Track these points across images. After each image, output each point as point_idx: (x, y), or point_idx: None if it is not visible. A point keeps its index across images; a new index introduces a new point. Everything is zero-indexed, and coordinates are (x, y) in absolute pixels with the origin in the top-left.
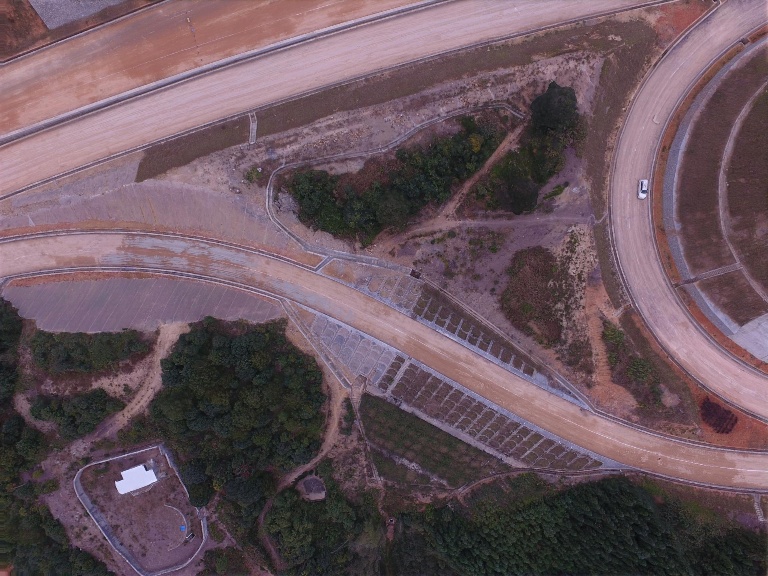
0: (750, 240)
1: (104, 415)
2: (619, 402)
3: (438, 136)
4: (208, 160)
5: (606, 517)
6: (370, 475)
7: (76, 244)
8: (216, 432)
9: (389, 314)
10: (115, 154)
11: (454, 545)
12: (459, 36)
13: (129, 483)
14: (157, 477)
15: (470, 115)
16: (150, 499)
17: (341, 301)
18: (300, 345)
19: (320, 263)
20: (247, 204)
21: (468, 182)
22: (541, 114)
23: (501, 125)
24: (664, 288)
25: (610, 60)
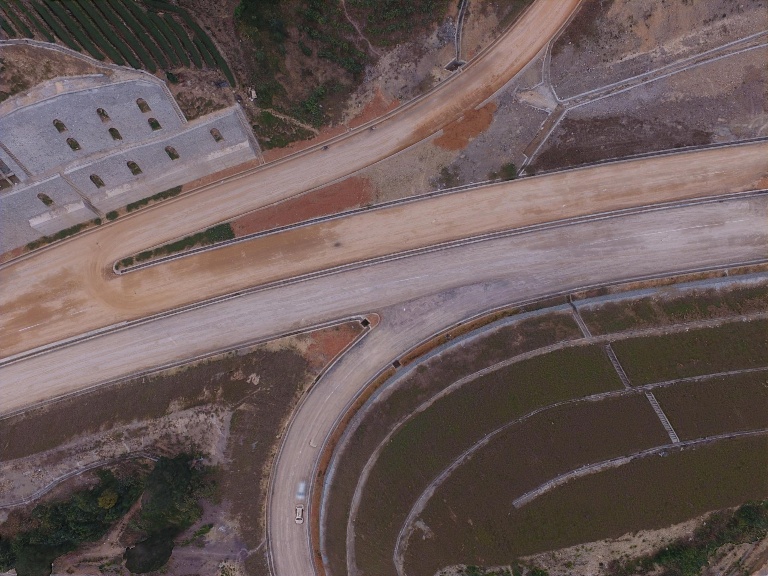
0: None
1: None
2: None
3: (72, 494)
4: None
5: None
6: None
7: None
8: None
9: None
10: None
11: None
12: (116, 366)
13: None
14: None
15: (106, 468)
16: None
17: None
18: None
19: None
20: None
21: (126, 514)
22: None
23: (144, 470)
24: None
25: (241, 410)
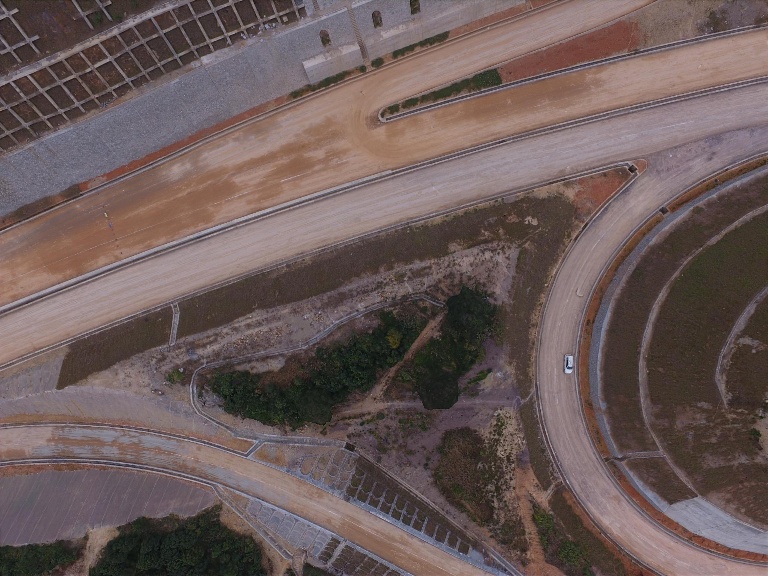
0: (671, 430)
1: None
2: None
3: (356, 334)
4: (128, 364)
5: None
6: None
7: (6, 438)
8: None
9: (322, 496)
10: (39, 350)
11: None
12: (379, 217)
13: None
14: None
15: (388, 310)
16: None
17: (274, 485)
18: (236, 526)
19: (251, 448)
20: (171, 403)
21: (393, 366)
22: (455, 317)
23: (421, 314)
24: (595, 462)
25: (526, 248)
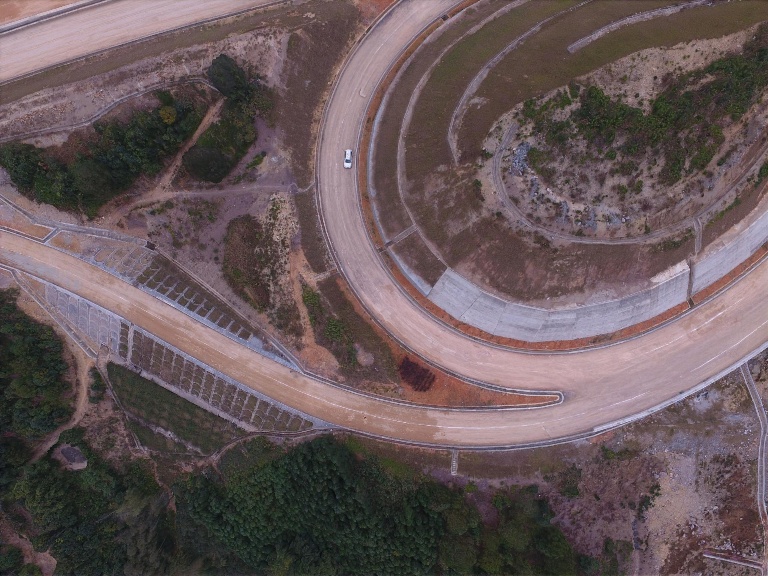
0: (422, 202)
1: None
2: (326, 363)
3: (132, 109)
4: None
5: (305, 473)
6: (133, 445)
7: None
8: None
9: (113, 283)
10: None
11: (205, 511)
12: (175, 17)
13: None
14: None
15: (166, 89)
16: None
17: (69, 271)
18: (36, 315)
19: (48, 235)
20: None
21: (180, 154)
22: None
23: (201, 99)
24: (370, 253)
25: (298, 35)
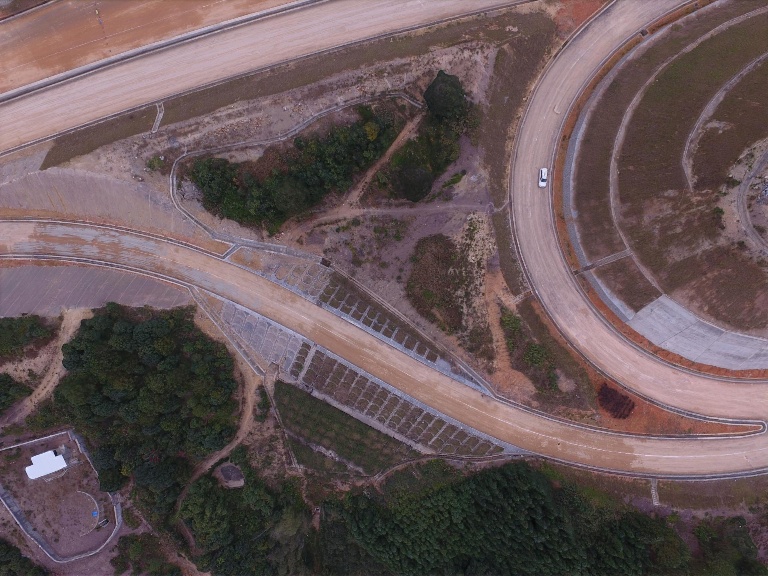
0: (638, 227)
1: (10, 400)
2: (519, 388)
3: (334, 125)
4: (111, 148)
5: (503, 501)
6: (289, 463)
7: None
8: (123, 417)
9: (295, 301)
10: (25, 143)
11: (369, 532)
12: (363, 28)
13: (39, 468)
14: (67, 462)
15: (367, 104)
16: (63, 485)
17: (248, 288)
18: (210, 332)
19: (228, 251)
20: (151, 192)
21: (370, 171)
22: (431, 102)
23: (399, 114)
24: (564, 275)
25: (505, 50)
